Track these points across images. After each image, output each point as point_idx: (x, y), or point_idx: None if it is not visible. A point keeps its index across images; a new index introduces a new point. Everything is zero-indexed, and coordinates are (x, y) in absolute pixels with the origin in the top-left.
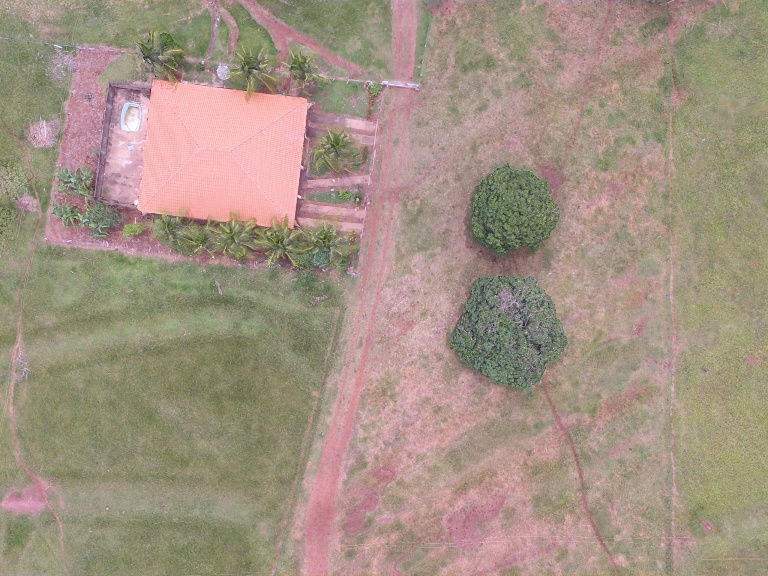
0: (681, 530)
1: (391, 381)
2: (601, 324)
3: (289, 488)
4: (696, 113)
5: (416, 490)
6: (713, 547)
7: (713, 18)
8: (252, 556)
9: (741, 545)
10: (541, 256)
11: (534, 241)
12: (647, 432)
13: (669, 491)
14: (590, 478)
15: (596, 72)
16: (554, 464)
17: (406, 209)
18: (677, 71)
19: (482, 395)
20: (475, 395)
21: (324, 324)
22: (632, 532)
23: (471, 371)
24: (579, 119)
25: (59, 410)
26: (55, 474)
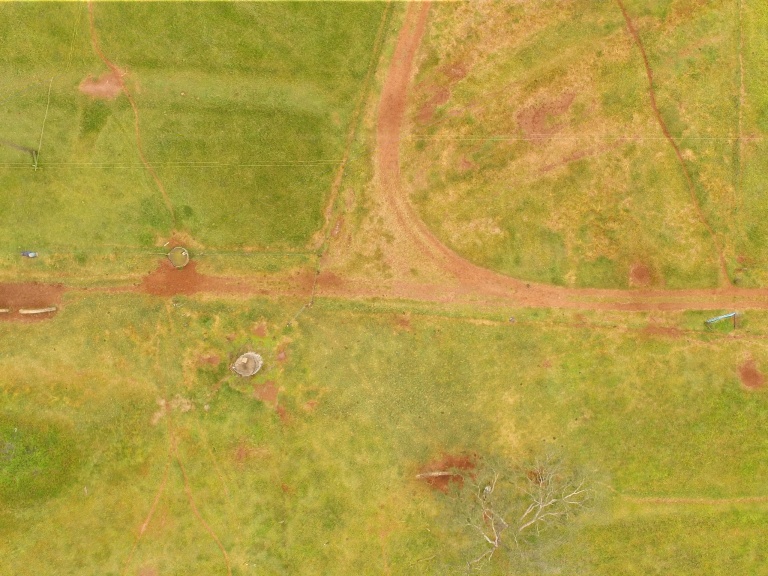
0: (748, 127)
1: None
2: None
3: (361, 81)
4: None
5: (487, 85)
6: None
7: None
8: (324, 145)
9: None
10: None
11: None
12: (717, 33)
13: (737, 90)
14: (659, 77)
15: None
16: (623, 65)
17: None
18: None
19: None
20: None
21: None
22: (700, 128)
23: None
24: None
25: (136, 2)
26: (131, 63)
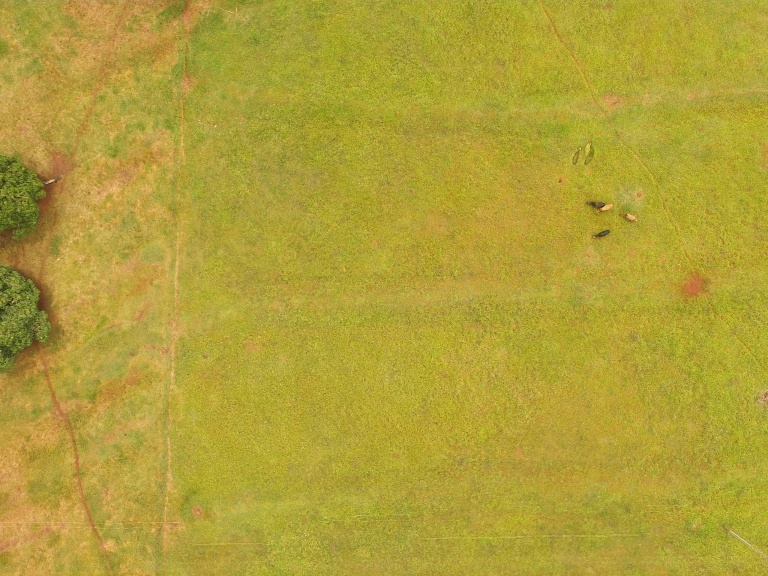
0: (172, 515)
1: None
2: (106, 310)
3: None
4: (206, 100)
5: None
6: (203, 532)
7: (229, 5)
8: None
9: (232, 530)
10: (49, 242)
11: None
12: (143, 417)
13: (163, 476)
14: (85, 463)
15: (111, 59)
16: (52, 450)
17: None
18: (189, 58)
19: None
20: None
21: None
22: (123, 517)
23: None
24: (92, 105)
25: None
26: None
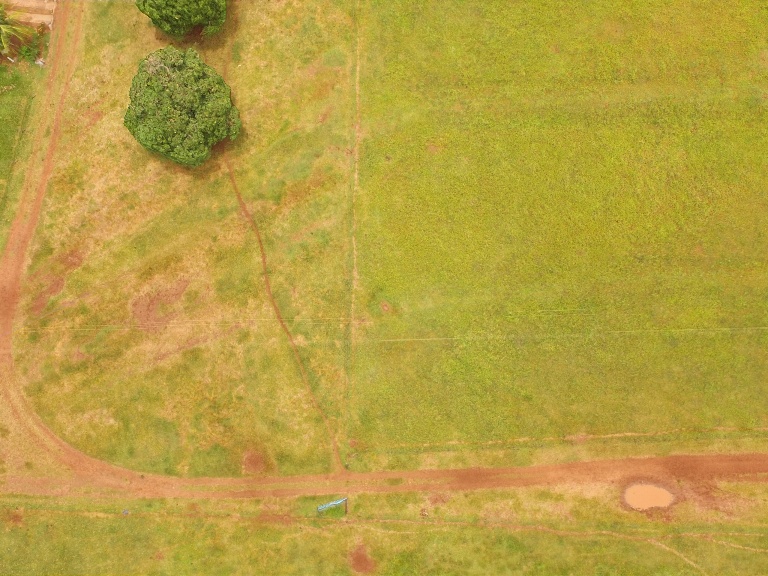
0: (359, 311)
1: (78, 169)
2: (288, 114)
3: None
4: None
5: (101, 275)
6: (390, 327)
7: None
8: None
9: (418, 326)
10: (231, 48)
11: (190, 11)
12: (329, 217)
13: (349, 274)
14: (272, 262)
15: None
16: (239, 250)
17: (97, 1)
18: None
19: (169, 183)
20: (161, 183)
21: (11, 112)
22: (312, 313)
23: (157, 159)
24: None
25: None
26: None
